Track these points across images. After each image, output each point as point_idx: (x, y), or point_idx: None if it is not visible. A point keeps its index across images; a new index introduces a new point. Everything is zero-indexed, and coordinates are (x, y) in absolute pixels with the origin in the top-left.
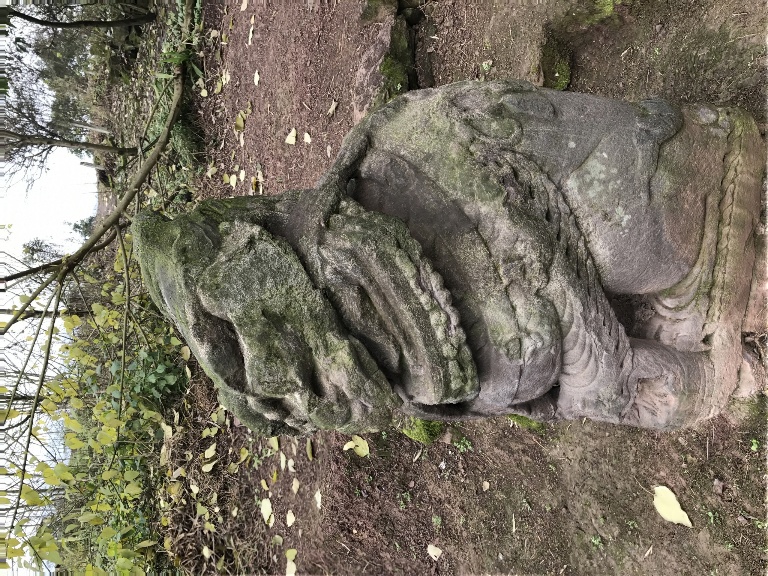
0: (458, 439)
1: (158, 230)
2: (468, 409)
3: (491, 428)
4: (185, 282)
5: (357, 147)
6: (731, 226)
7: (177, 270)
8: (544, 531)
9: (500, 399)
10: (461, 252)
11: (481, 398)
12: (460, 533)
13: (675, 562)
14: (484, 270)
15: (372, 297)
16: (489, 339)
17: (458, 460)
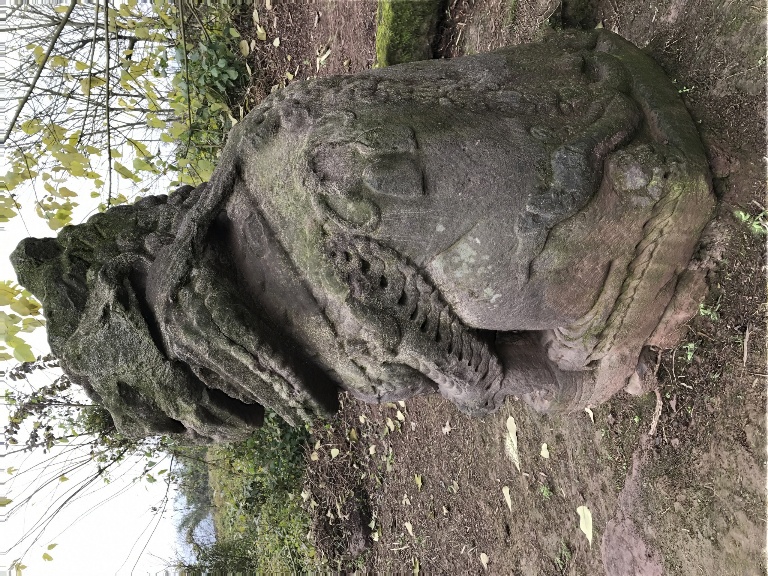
0: None
1: (32, 277)
2: None
3: None
4: (52, 350)
5: (222, 184)
6: (643, 279)
7: None
8: None
9: None
10: (308, 329)
11: None
12: None
13: (580, 433)
14: (329, 347)
15: None
16: (344, 382)
17: None
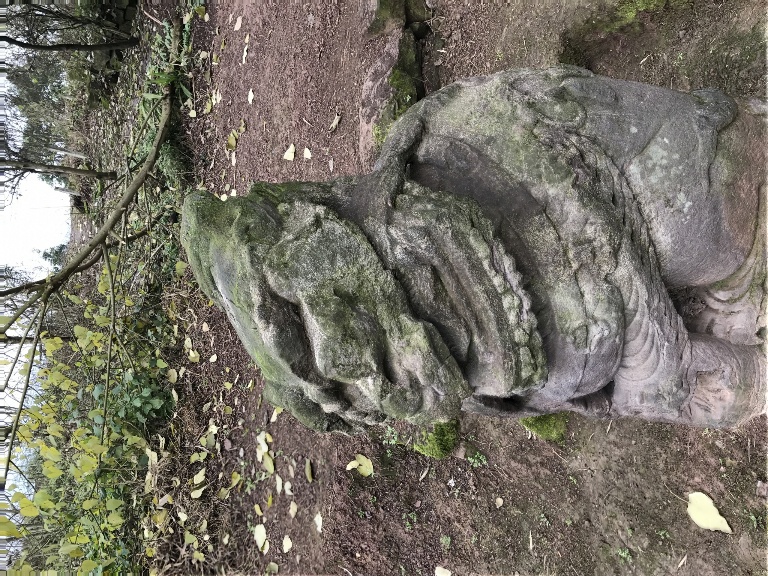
0: (472, 453)
1: (215, 210)
2: (524, 405)
3: (507, 441)
4: (251, 261)
5: (413, 132)
6: None
7: (241, 249)
8: (565, 546)
9: (562, 392)
10: (529, 235)
11: (539, 392)
12: (471, 553)
13: (713, 571)
14: (554, 253)
15: (444, 279)
16: (556, 327)
17: (469, 477)
